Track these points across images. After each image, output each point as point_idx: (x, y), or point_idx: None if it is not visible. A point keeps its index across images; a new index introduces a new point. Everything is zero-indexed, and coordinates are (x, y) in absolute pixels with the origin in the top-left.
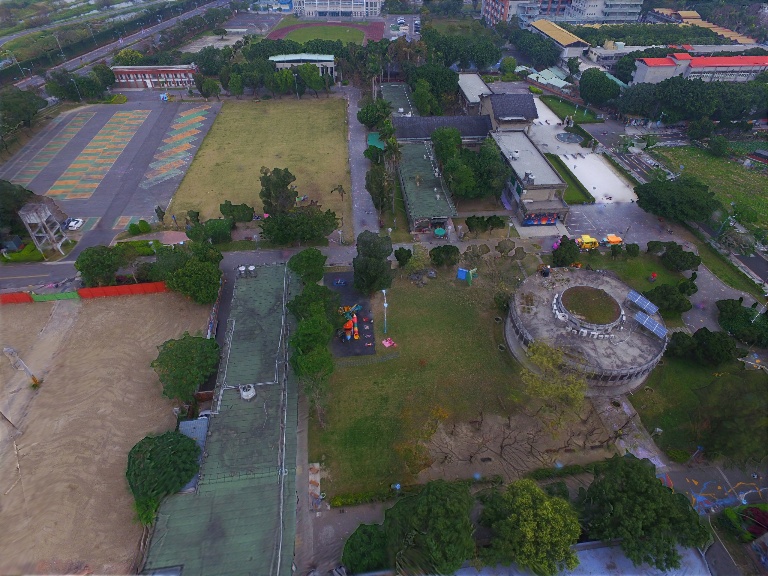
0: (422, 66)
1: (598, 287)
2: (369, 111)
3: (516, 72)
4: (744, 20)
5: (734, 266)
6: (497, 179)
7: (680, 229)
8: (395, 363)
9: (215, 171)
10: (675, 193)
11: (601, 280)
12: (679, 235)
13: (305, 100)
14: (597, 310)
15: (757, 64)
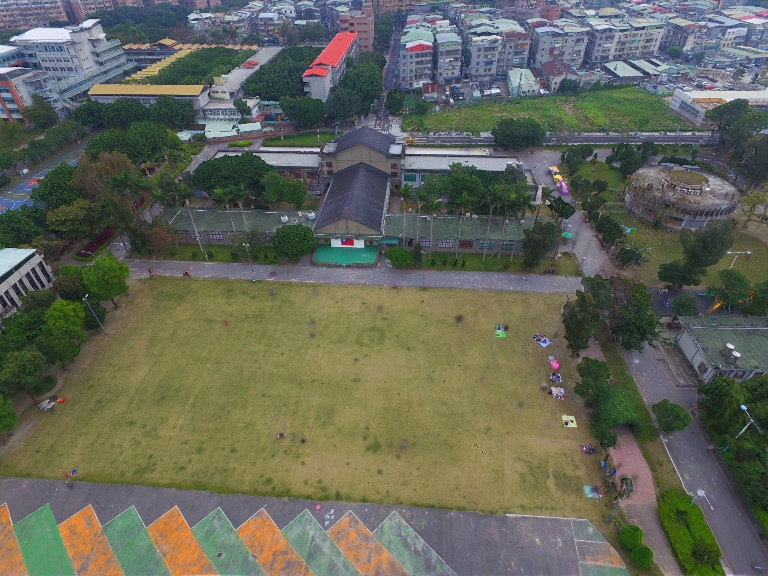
0: (204, 169)
1: (652, 176)
2: (302, 236)
3: (186, 141)
4: (229, 33)
5: (573, 145)
6: (526, 177)
7: (528, 149)
8: (755, 282)
9: (402, 448)
10: (523, 128)
11: (643, 174)
12: (535, 151)
13: (113, 325)
14: (694, 176)
15: (344, 53)
